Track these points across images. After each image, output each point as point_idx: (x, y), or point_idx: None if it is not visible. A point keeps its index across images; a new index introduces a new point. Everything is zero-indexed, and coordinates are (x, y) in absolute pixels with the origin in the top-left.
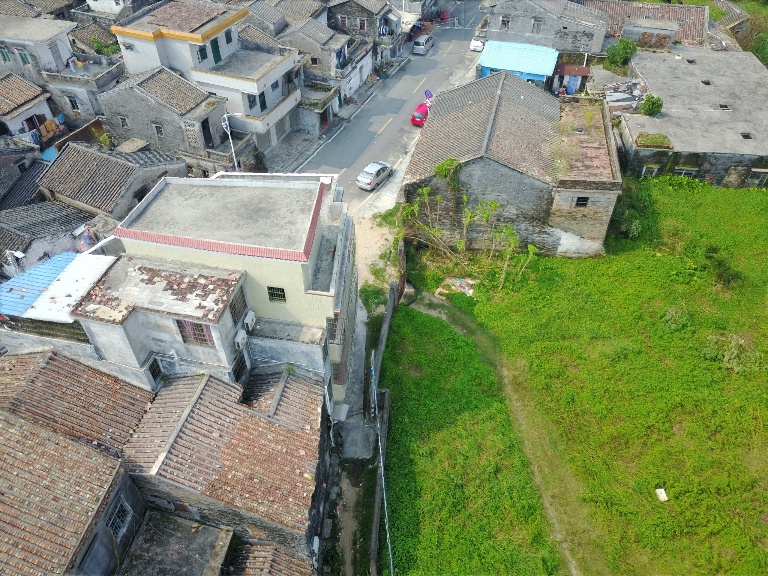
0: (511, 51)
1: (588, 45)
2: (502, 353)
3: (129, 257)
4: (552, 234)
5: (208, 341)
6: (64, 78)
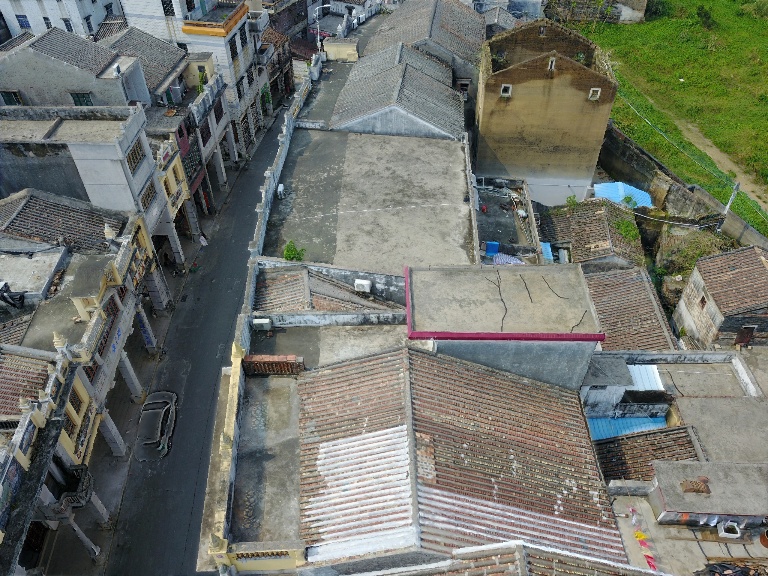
0: None
1: None
2: None
3: None
4: (618, 8)
5: None
6: None
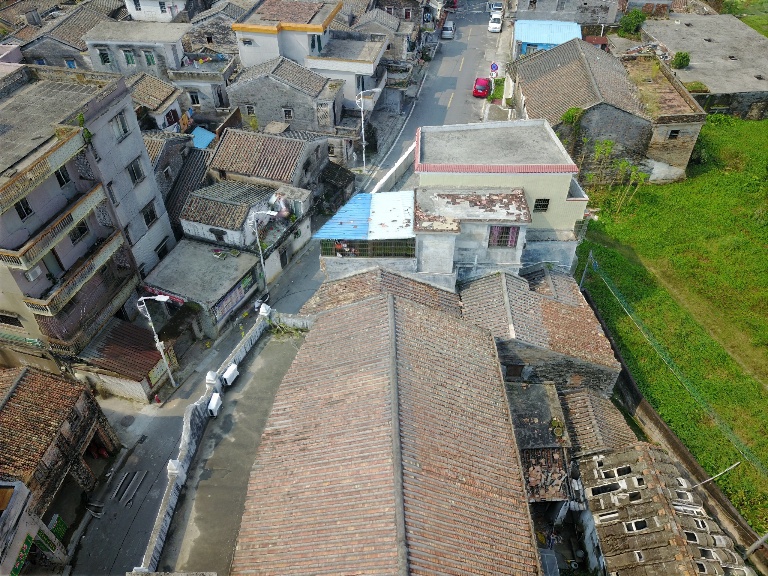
0: (540, 27)
1: (604, 17)
2: (644, 258)
3: (423, 189)
4: (647, 165)
5: (509, 243)
6: (191, 75)
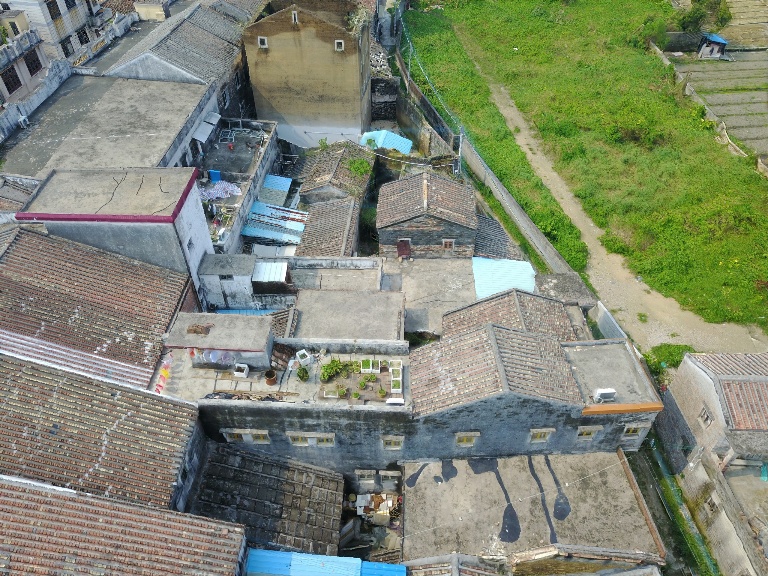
0: None
1: None
2: (454, 23)
3: None
4: None
5: None
6: None
